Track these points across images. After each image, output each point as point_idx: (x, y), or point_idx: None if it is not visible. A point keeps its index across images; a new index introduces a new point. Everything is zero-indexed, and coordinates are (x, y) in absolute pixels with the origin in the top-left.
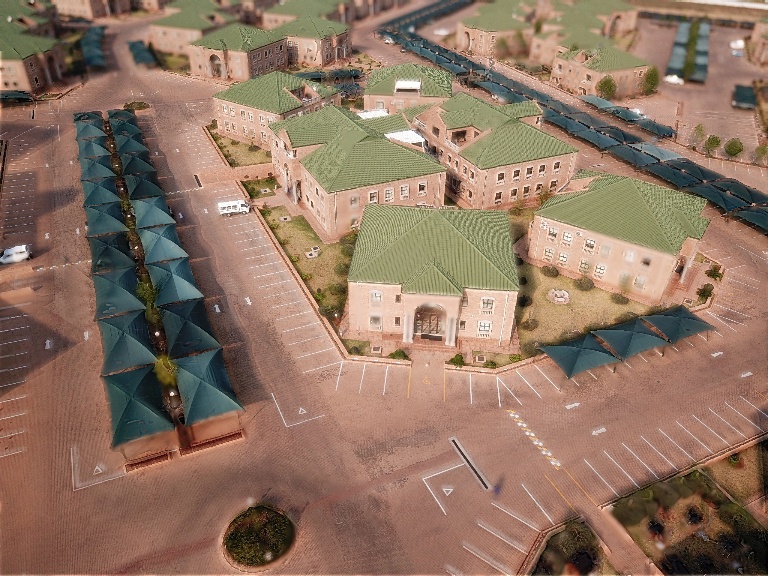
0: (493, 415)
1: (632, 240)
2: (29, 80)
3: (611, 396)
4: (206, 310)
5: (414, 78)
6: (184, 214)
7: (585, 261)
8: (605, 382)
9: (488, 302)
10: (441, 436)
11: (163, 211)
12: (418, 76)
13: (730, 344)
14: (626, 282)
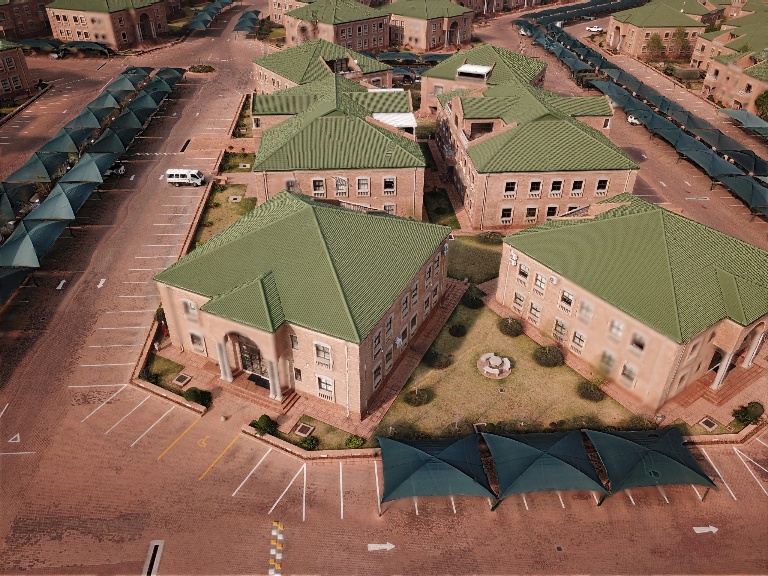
0: (247, 523)
1: (620, 305)
2: (115, 34)
3: (456, 550)
4: (48, 284)
5: (487, 62)
6: (137, 176)
7: (562, 323)
8: (465, 522)
9: (324, 350)
10: (146, 533)
11: (97, 167)
12: (492, 60)
13: (742, 518)
14: (611, 368)
